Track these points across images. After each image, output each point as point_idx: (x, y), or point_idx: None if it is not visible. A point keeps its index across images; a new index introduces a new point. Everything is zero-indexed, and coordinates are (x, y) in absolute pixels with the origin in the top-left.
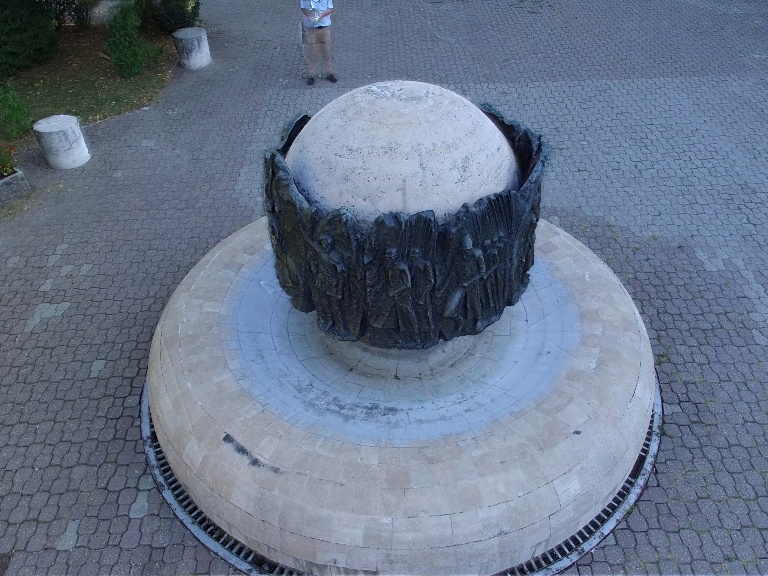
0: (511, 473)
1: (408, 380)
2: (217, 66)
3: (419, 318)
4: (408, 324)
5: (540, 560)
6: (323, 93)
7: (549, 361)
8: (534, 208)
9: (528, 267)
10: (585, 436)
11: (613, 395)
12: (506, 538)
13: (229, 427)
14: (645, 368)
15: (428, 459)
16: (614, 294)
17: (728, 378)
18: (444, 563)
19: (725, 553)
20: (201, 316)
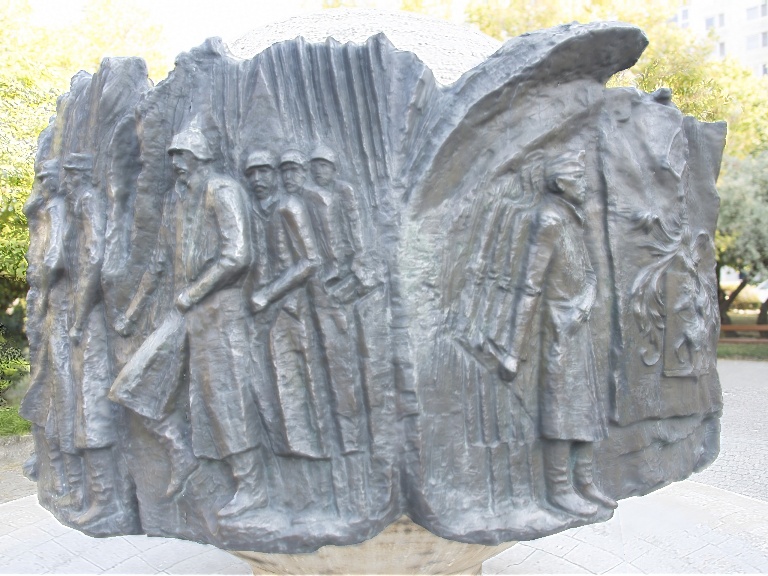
0: None
1: None
2: None
3: None
4: None
5: None
6: None
7: None
8: (560, 190)
9: (553, 420)
10: None
11: None
12: None
13: None
14: None
15: None
16: None
17: None
18: None
19: None
20: None
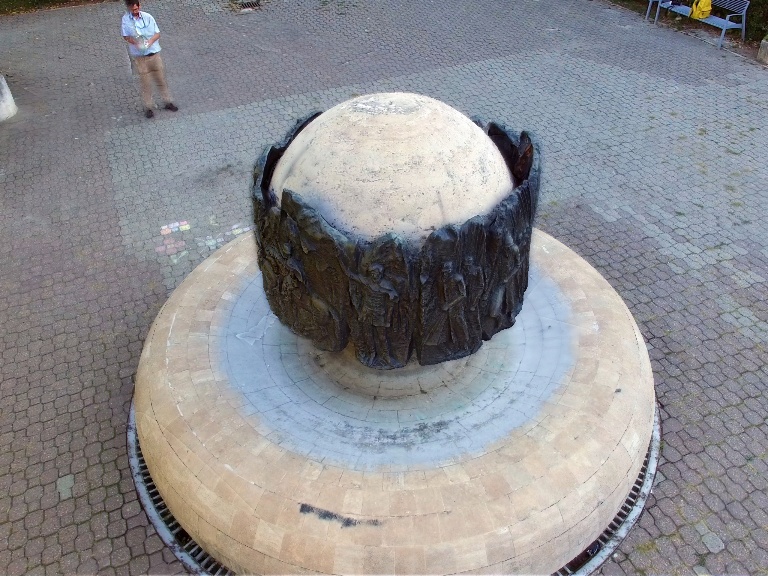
0: (588, 446)
1: (435, 391)
2: (27, 114)
3: (469, 325)
4: (460, 334)
5: (617, 517)
6: (169, 124)
7: (555, 335)
8: None
9: None
10: (625, 392)
11: (626, 349)
12: (603, 507)
13: (300, 496)
14: (631, 318)
15: (512, 459)
16: (575, 260)
17: (672, 309)
18: (560, 551)
19: (745, 455)
20: (197, 390)
